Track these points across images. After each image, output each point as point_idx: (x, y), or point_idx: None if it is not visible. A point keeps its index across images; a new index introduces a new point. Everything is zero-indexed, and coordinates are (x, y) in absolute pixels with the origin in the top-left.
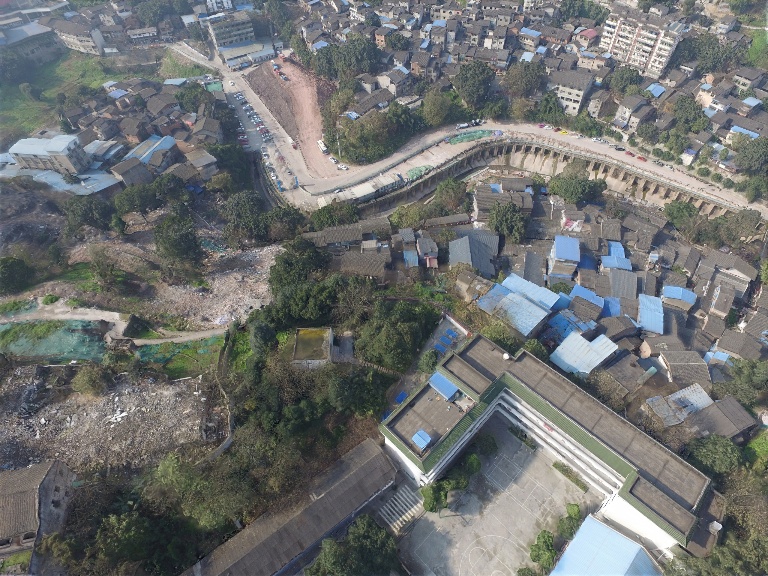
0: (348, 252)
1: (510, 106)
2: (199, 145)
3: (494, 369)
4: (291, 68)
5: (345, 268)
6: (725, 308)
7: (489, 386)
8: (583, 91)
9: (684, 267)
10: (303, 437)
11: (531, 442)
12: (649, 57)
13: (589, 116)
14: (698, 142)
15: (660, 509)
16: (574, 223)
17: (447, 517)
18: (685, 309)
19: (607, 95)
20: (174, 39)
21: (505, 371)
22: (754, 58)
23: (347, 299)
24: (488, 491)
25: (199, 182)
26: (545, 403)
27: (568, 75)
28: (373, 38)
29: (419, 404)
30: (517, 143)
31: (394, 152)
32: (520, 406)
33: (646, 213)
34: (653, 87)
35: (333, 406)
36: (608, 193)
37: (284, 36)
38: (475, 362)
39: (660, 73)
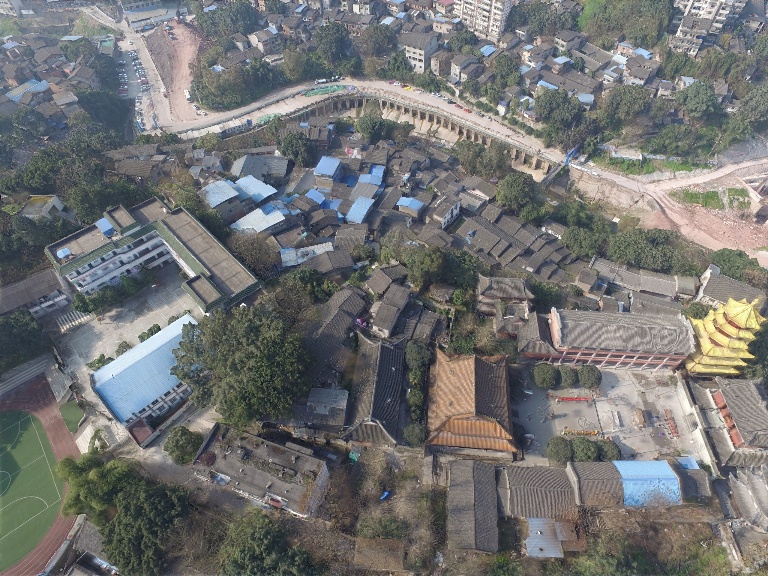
0: (128, 159)
1: (363, 64)
2: (68, 88)
3: (153, 219)
4: (182, 29)
5: (120, 170)
6: (442, 214)
7: (132, 224)
8: (424, 50)
9: (434, 187)
10: (6, 265)
11: (181, 275)
12: (488, 22)
13: (432, 74)
14: (509, 95)
15: (204, 293)
16: (354, 151)
17: (105, 324)
18: (415, 216)
19: (446, 54)
20: (88, 3)
21: (157, 219)
22: (583, 24)
23: (70, 174)
24: (144, 309)
25: (62, 119)
26: (174, 238)
27: (412, 36)
28: (258, 3)
29: (83, 237)
30: (366, 97)
31: (252, 102)
32: (166, 244)
33: (436, 150)
34: (486, 48)
35: (25, 240)
36: (428, 138)
37: (188, 2)
38: (142, 215)
39: (498, 36)
